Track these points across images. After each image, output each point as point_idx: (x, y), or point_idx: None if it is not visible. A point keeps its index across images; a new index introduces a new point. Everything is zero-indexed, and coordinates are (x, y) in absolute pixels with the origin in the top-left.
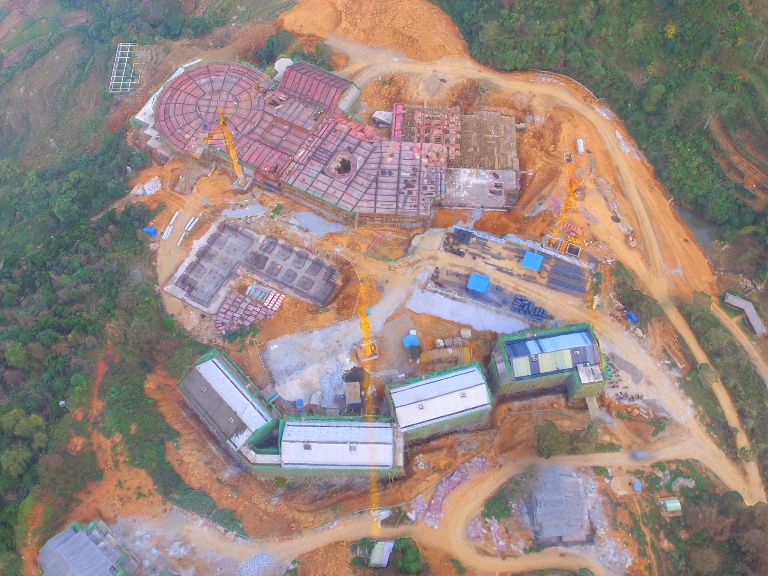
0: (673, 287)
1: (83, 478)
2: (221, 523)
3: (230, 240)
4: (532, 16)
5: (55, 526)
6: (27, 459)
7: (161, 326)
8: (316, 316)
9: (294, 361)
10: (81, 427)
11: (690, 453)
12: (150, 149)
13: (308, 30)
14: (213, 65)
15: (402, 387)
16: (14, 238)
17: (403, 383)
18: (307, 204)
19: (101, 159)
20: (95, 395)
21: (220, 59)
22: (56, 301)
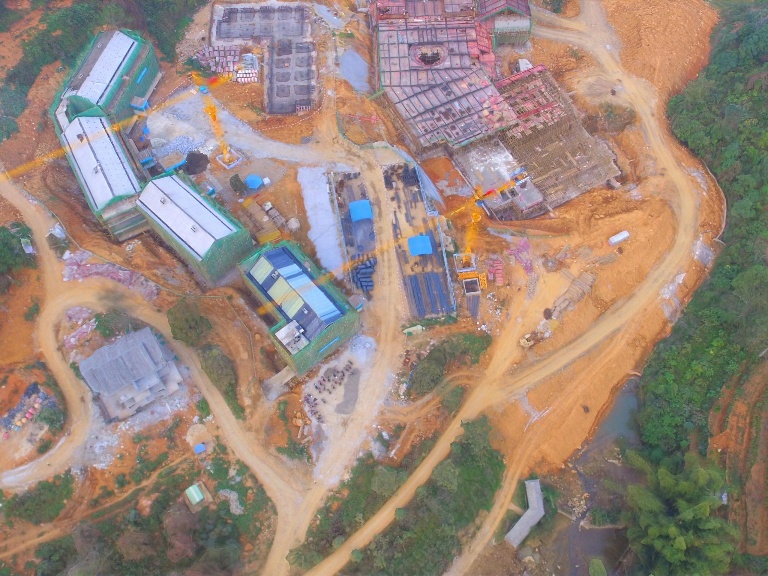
0: (498, 410)
1: None
2: None
3: (291, 20)
4: (759, 112)
5: None
6: None
7: (178, 18)
8: (247, 108)
9: (188, 111)
10: (40, 0)
11: (280, 500)
12: None
13: None
14: None
15: (183, 182)
16: None
17: None
18: None
19: None
20: None
21: None
22: None
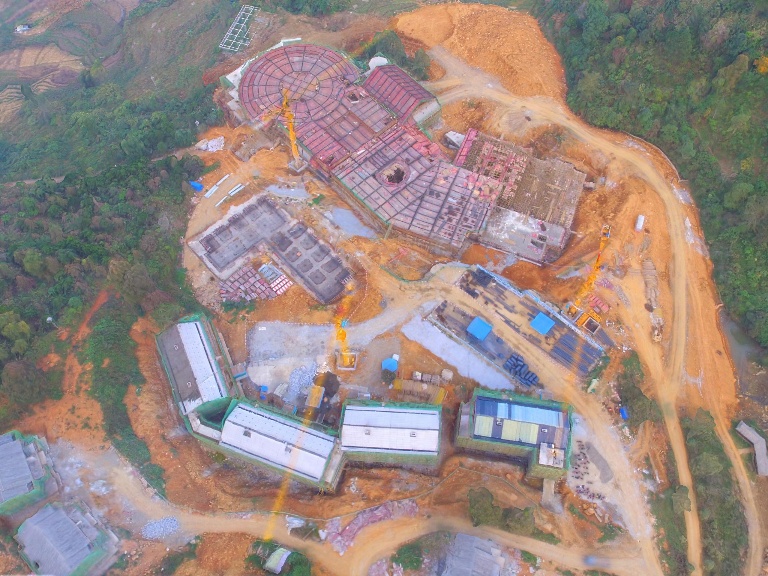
0: (683, 396)
1: (40, 393)
2: (147, 477)
3: (264, 215)
4: (639, 77)
5: (3, 428)
6: (3, 359)
7: (172, 276)
8: (313, 311)
9: (275, 348)
10: (62, 346)
11: (632, 573)
12: (229, 110)
13: (417, 35)
14: (311, 46)
15: (359, 407)
16: (87, 157)
17: (362, 403)
18: (350, 202)
19: (184, 107)
20: (86, 321)
21: (327, 42)
22: (89, 225)
